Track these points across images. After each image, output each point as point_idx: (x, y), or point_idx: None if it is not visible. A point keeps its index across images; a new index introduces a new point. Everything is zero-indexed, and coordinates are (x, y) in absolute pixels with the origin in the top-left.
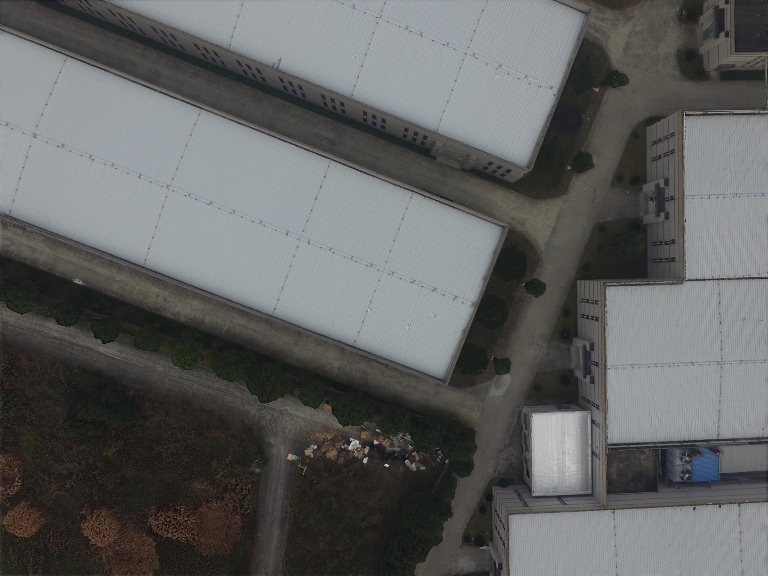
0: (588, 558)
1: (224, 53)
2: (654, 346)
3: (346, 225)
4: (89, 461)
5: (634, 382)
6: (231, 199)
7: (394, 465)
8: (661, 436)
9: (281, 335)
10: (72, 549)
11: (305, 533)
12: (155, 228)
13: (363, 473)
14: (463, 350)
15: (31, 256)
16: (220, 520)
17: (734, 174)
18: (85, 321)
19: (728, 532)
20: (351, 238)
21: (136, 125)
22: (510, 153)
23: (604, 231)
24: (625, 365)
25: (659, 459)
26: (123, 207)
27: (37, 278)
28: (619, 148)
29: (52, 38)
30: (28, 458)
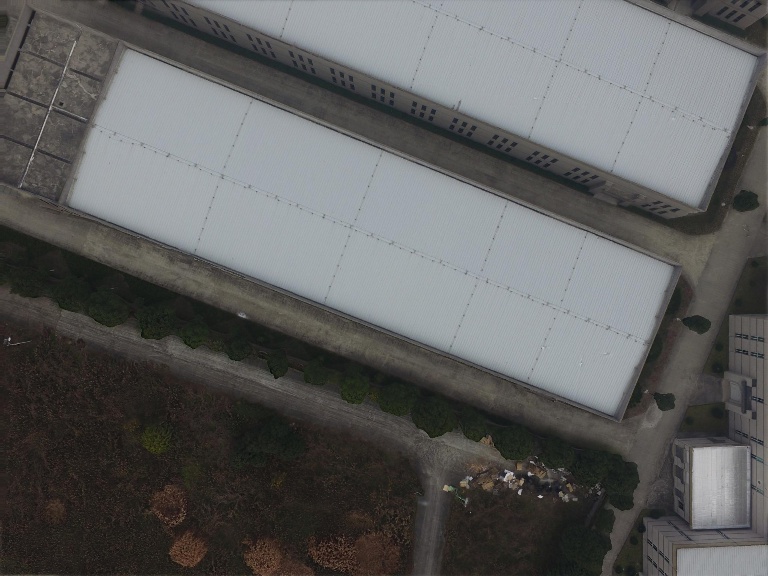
0: None
1: (404, 95)
2: None
3: (523, 264)
4: (251, 492)
5: None
6: (412, 239)
7: (548, 496)
8: None
9: (439, 368)
10: None
11: (460, 563)
12: (337, 267)
13: (517, 504)
14: None
15: (197, 290)
16: (377, 550)
17: None
18: (256, 356)
19: None
20: (528, 277)
21: (320, 166)
22: (682, 194)
23: (757, 267)
24: None
25: None
26: (306, 246)
27: (203, 312)
28: None
29: (220, 76)
30: (192, 489)
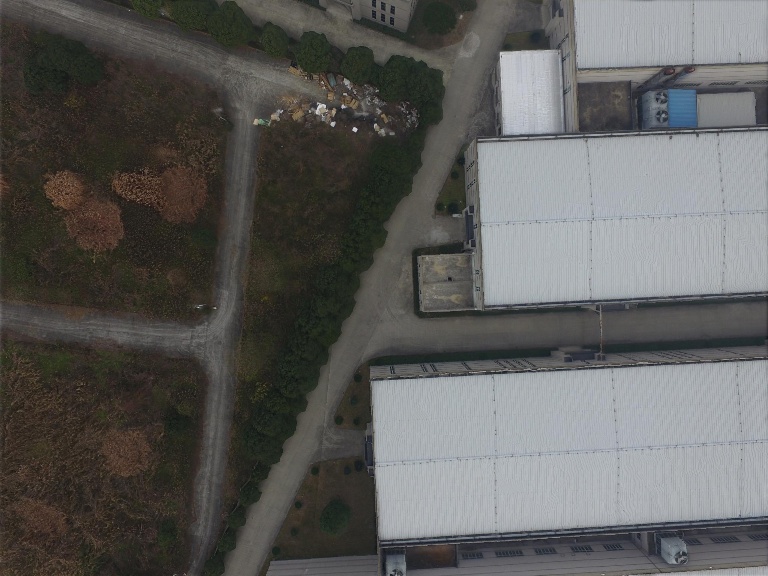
0: (561, 187)
1: None
2: None
3: None
4: (52, 125)
5: (603, 1)
6: None
7: (362, 129)
8: (633, 61)
9: None
10: (35, 213)
11: (273, 199)
12: None
13: (331, 137)
14: (430, 8)
15: None
16: (186, 187)
17: None
18: None
19: (707, 162)
20: None
21: None
22: None
23: None
24: None
25: (636, 118)
26: None
27: None
28: None
29: None
30: None
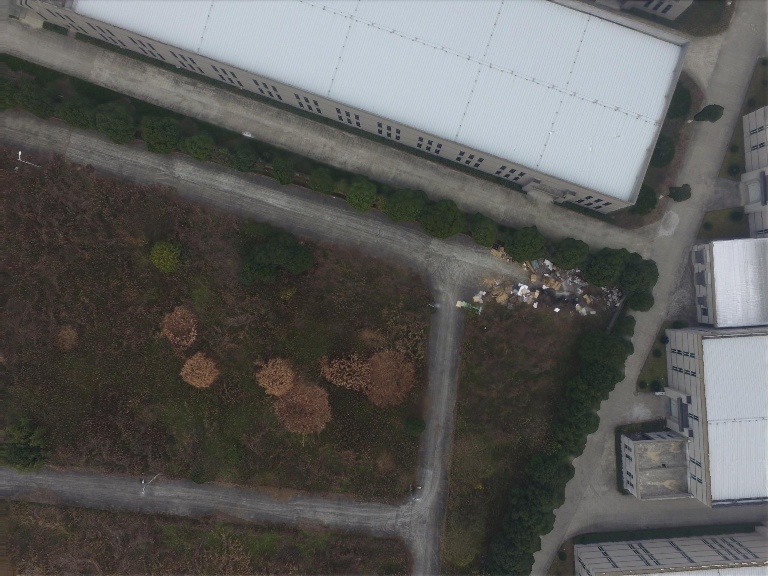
0: None
1: None
2: None
3: (526, 49)
4: (261, 312)
5: None
6: (413, 27)
7: (565, 309)
8: None
9: (447, 181)
10: (247, 400)
11: (477, 381)
12: (339, 59)
13: (533, 318)
14: None
15: (202, 111)
16: (391, 369)
17: None
18: (262, 164)
19: None
20: (532, 61)
21: None
22: None
23: None
24: None
25: None
26: (308, 39)
27: (209, 131)
28: None
29: None
30: (202, 310)
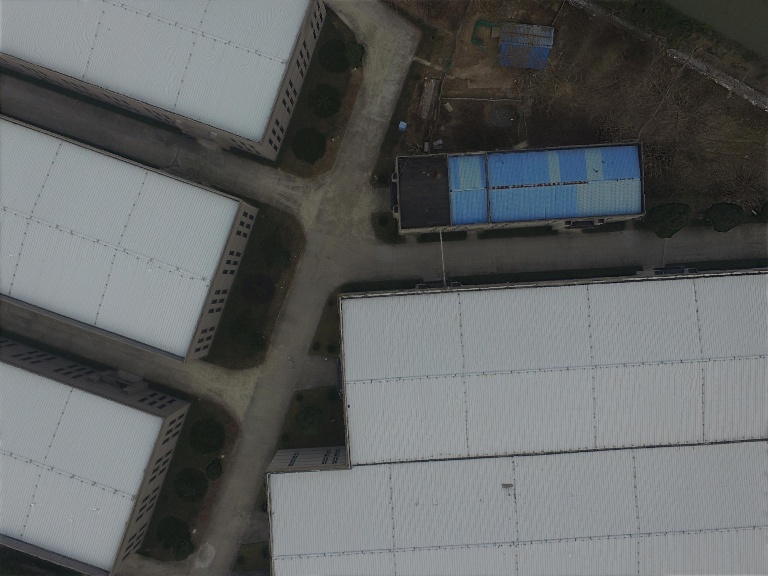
0: None
1: None
2: (323, 535)
3: (6, 422)
4: None
5: (304, 572)
6: None
7: None
8: None
9: None
10: None
11: None
12: None
13: None
14: (163, 524)
15: None
16: None
17: (398, 357)
18: None
19: None
20: (10, 435)
21: None
22: (168, 344)
23: (301, 400)
24: (292, 555)
25: None
26: None
27: None
28: (316, 315)
29: None
30: None
